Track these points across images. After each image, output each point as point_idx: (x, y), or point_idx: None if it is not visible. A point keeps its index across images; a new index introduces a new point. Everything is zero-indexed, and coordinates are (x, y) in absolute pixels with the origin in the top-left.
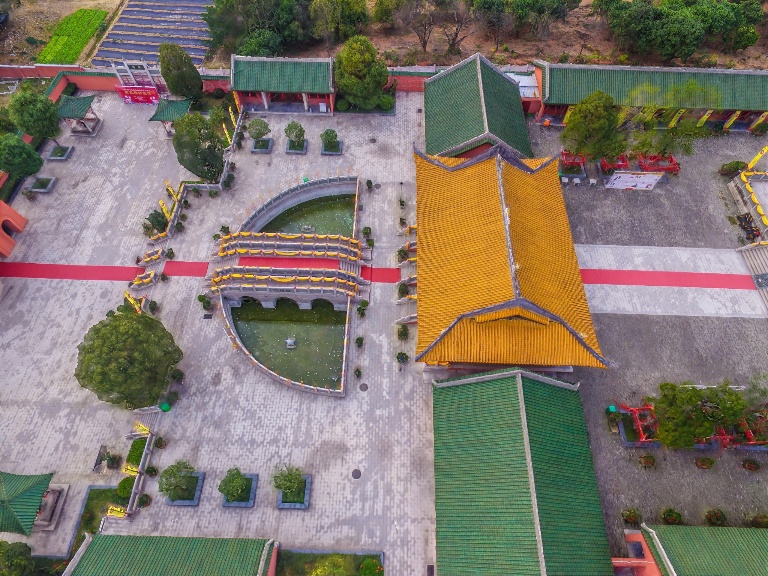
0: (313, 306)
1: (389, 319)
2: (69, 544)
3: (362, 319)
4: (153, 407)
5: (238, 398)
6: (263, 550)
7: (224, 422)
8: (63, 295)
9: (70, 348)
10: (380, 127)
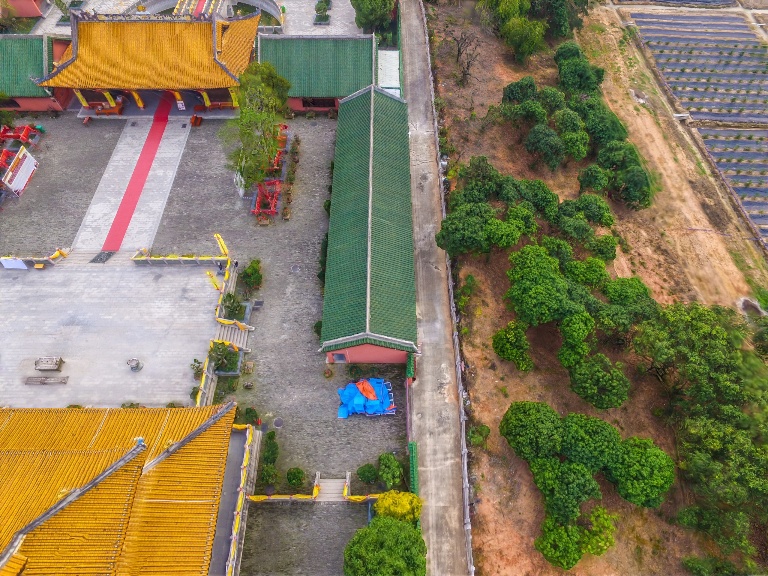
0: None
1: None
2: None
3: None
4: None
5: (127, 1)
6: None
7: None
8: None
9: None
10: None
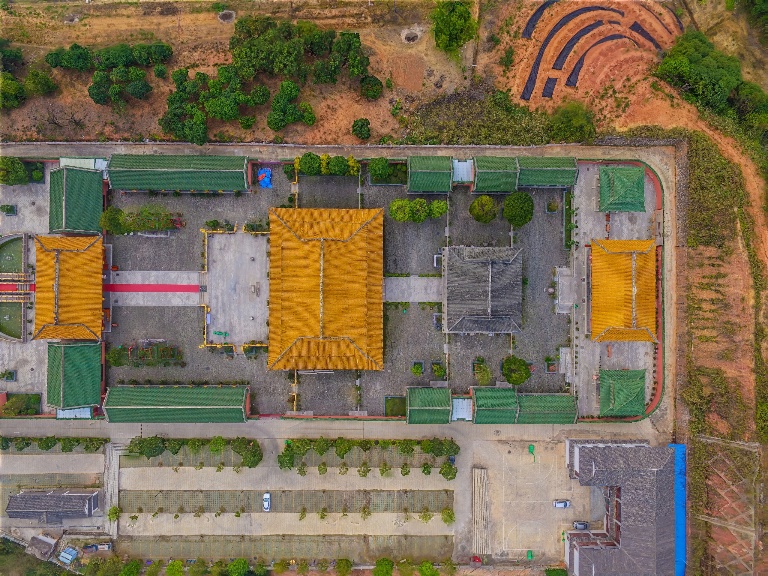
0: None
1: None
2: None
3: (32, 310)
4: None
5: None
6: None
7: None
8: None
9: None
10: (37, 193)
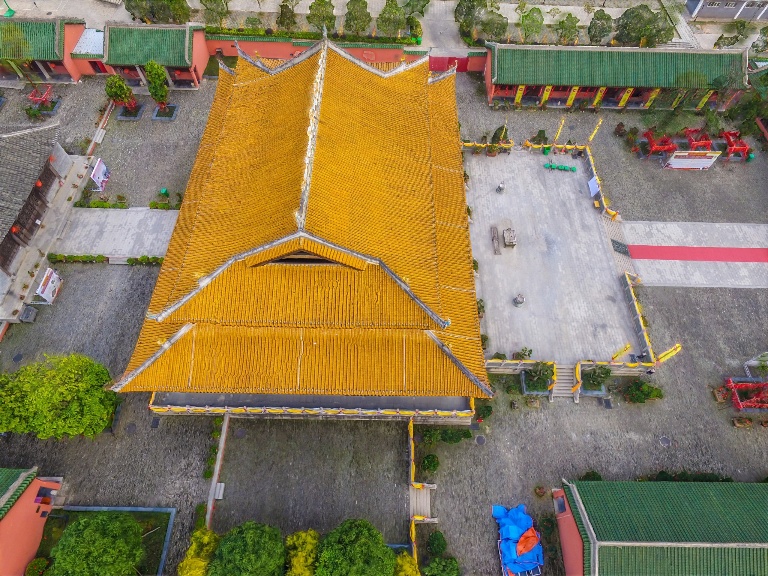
0: None
1: None
2: None
3: None
4: None
5: None
6: None
7: None
8: None
9: None
10: None
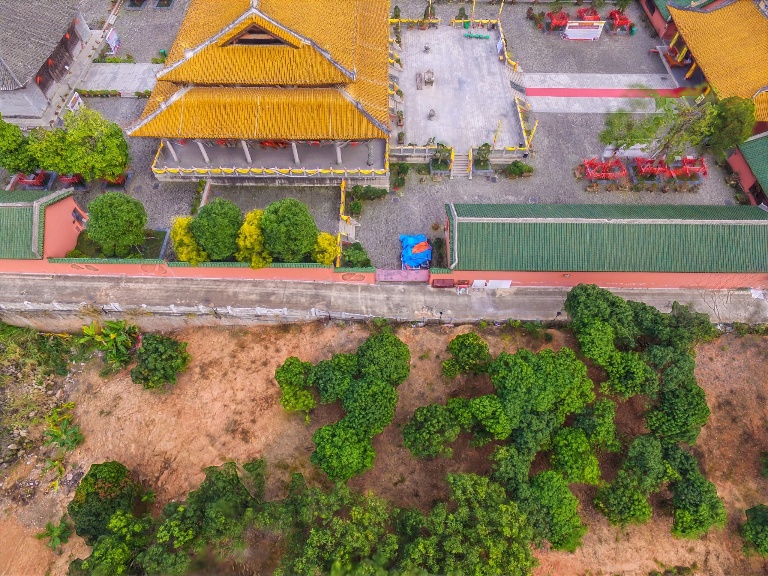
0: None
1: None
2: None
3: None
4: None
5: None
6: None
7: None
8: None
9: None
10: None
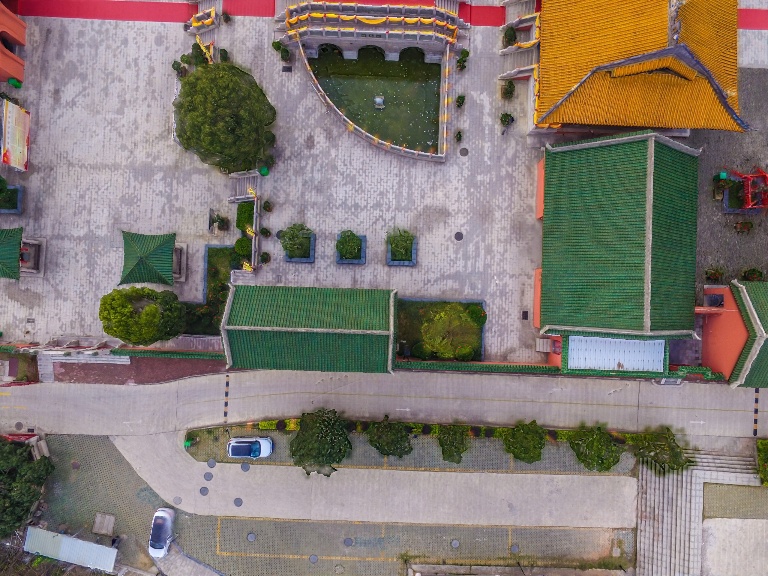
0: (400, 57)
1: (491, 74)
2: (203, 292)
3: (461, 73)
4: (252, 171)
5: (335, 162)
6: (390, 298)
7: (325, 187)
8: (112, 41)
9: (142, 107)
10: None
